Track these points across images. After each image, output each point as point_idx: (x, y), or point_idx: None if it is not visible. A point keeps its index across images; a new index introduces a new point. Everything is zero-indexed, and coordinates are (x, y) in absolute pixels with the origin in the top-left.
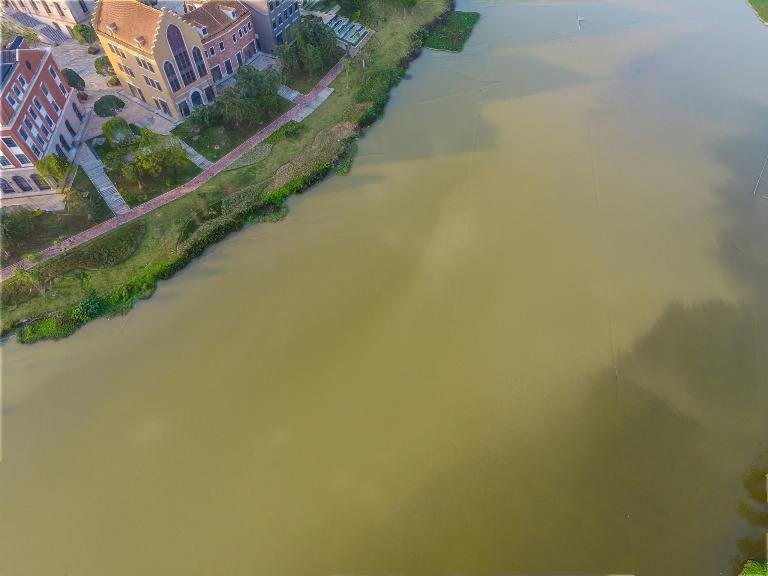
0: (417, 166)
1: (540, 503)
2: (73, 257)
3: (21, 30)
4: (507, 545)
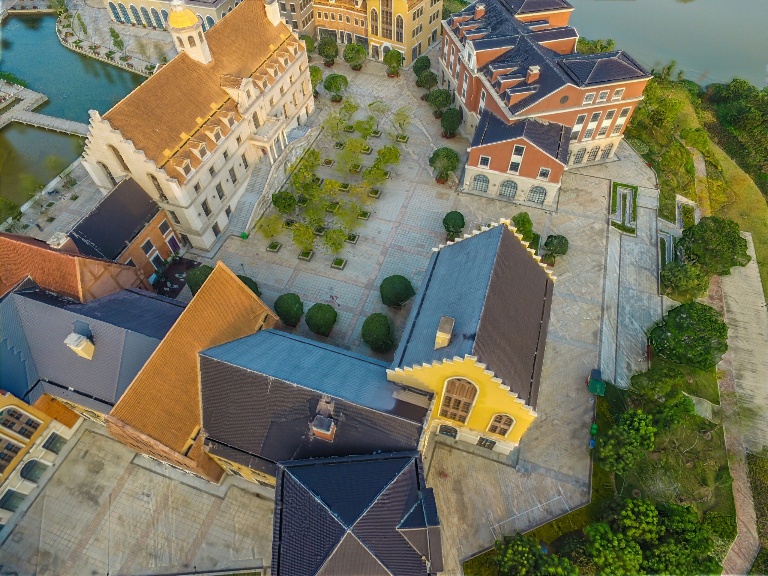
0: None
1: None
2: None
3: (302, 148)
4: None
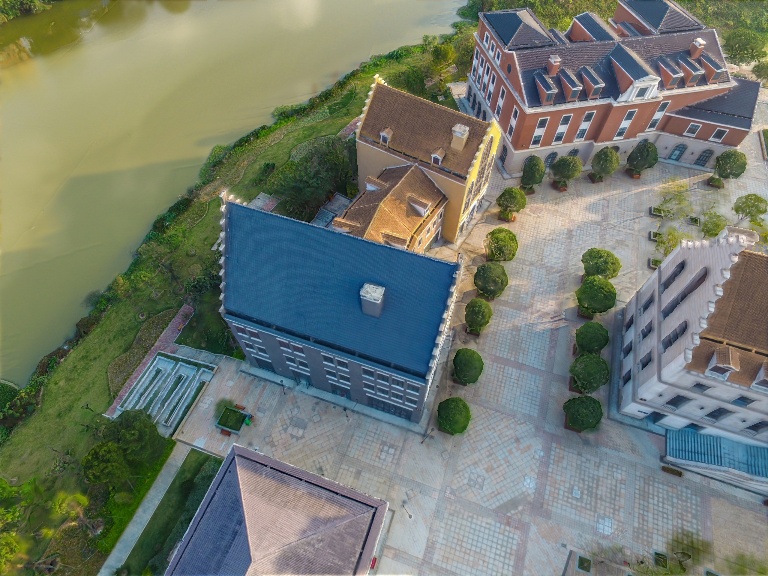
0: (141, 157)
1: (154, 8)
2: (423, 71)
3: None
4: (175, 0)
